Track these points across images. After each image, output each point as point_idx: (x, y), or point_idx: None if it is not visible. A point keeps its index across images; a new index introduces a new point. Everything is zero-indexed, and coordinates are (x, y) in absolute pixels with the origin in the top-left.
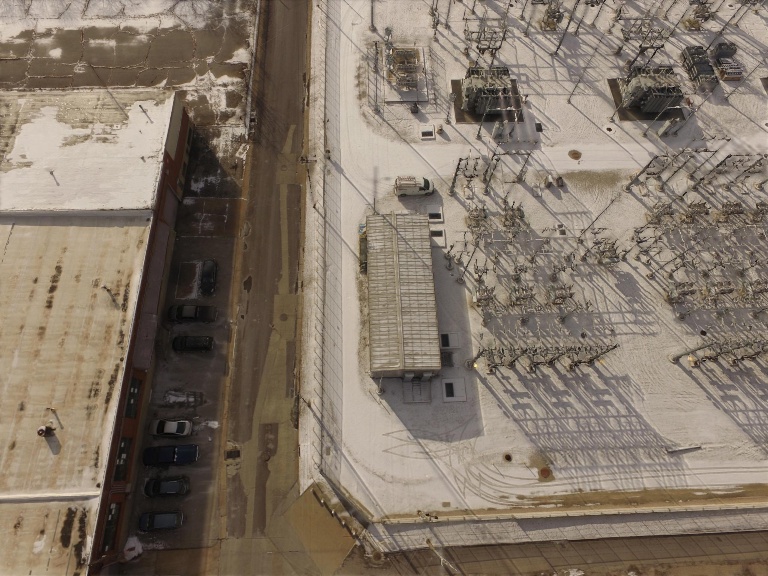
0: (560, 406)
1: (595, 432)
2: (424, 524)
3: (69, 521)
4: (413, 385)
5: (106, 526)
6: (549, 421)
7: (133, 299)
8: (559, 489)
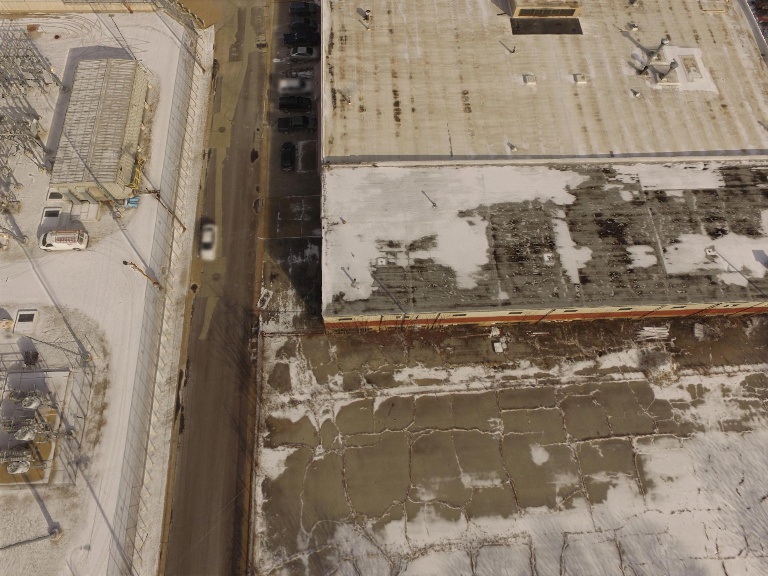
0: None
1: None
2: None
3: None
4: None
5: None
6: None
7: (327, 96)
8: (27, 21)
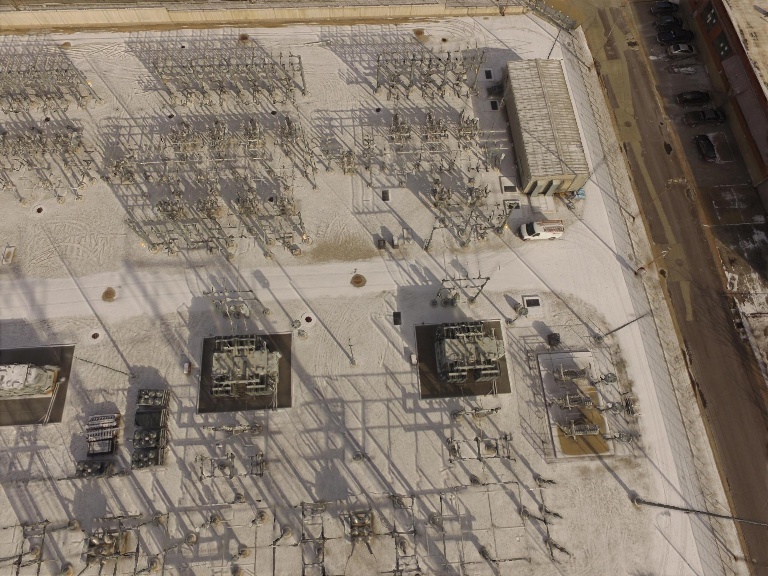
0: None
1: None
2: None
3: None
4: None
5: None
6: None
7: (764, 90)
8: (410, 25)
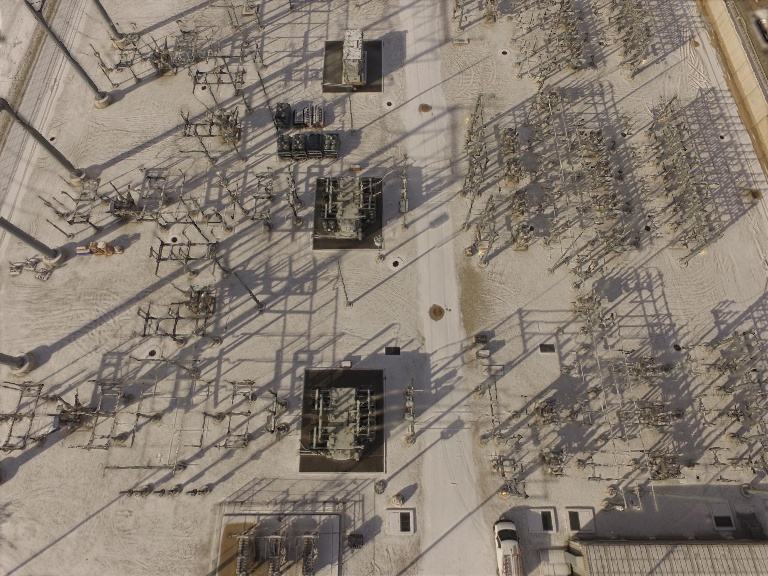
0: (765, 389)
1: None
2: None
3: None
4: None
5: None
6: None
7: None
8: None
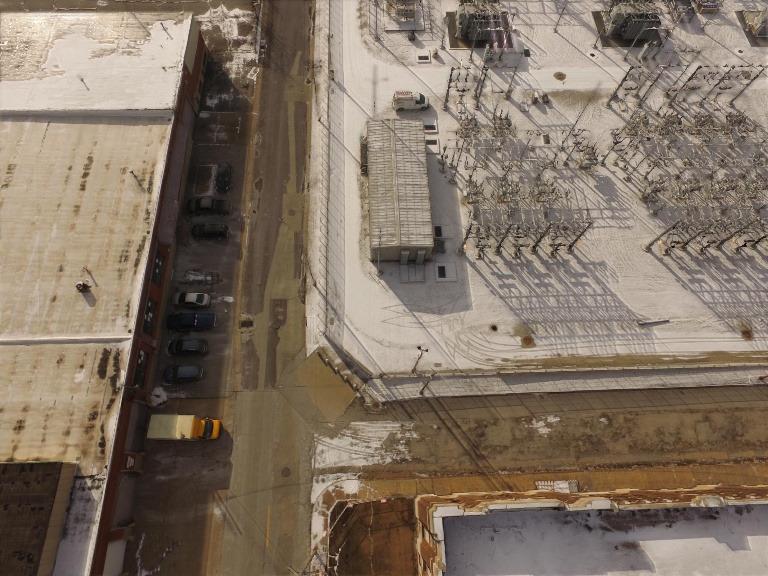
0: (542, 286)
1: (573, 308)
2: (418, 379)
3: (105, 358)
4: (409, 267)
5: (137, 366)
6: (532, 298)
7: (157, 184)
8: (540, 354)
